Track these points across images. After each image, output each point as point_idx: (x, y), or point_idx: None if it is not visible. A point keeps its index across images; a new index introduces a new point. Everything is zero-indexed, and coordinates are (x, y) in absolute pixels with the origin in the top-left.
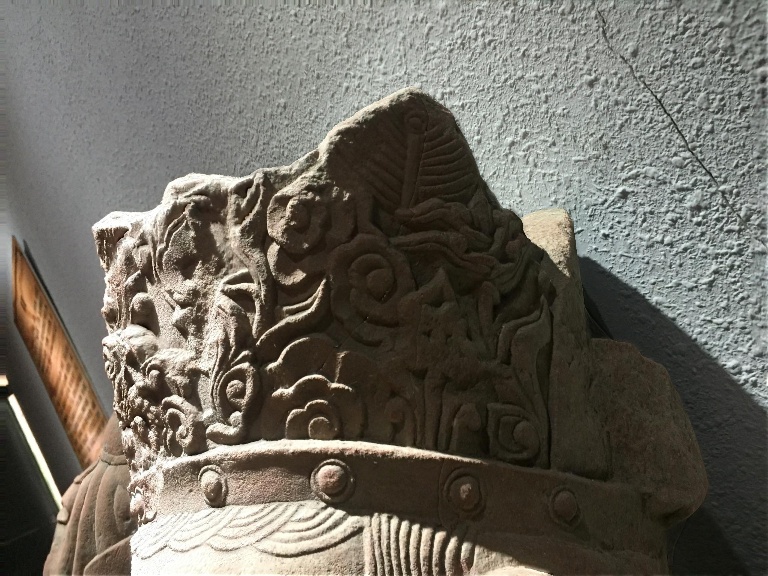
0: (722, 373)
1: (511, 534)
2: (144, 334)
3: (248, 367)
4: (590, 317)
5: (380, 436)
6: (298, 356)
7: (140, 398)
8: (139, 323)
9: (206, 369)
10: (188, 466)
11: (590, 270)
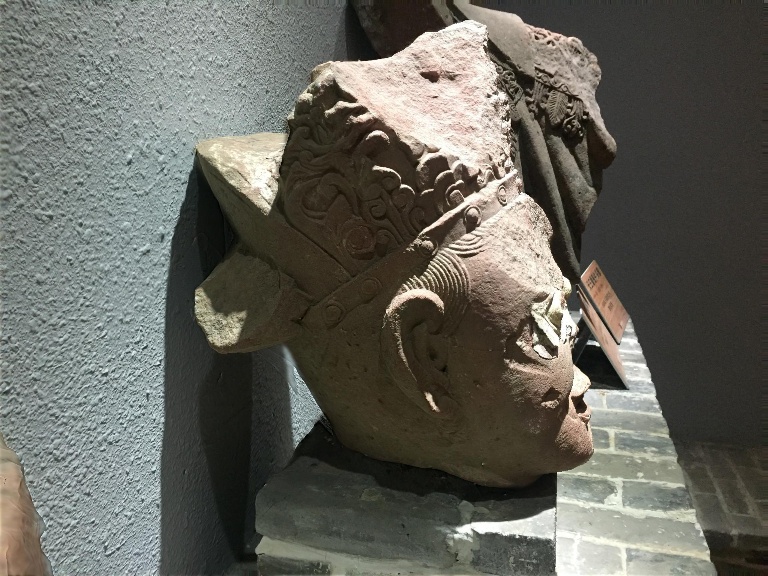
0: None
1: None
2: None
3: None
4: None
5: None
6: None
7: None
8: None
9: None
10: None
11: None
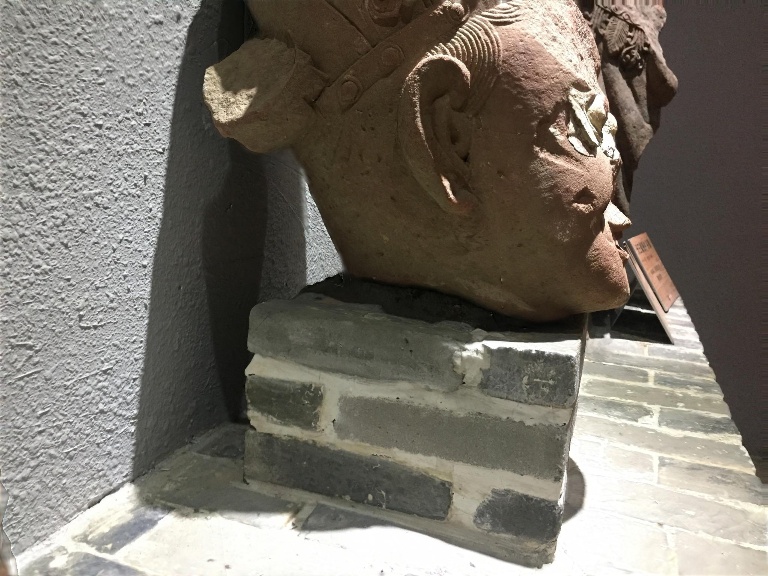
0: None
1: None
2: None
3: None
4: None
5: None
6: None
7: None
8: None
9: None
10: None
11: None
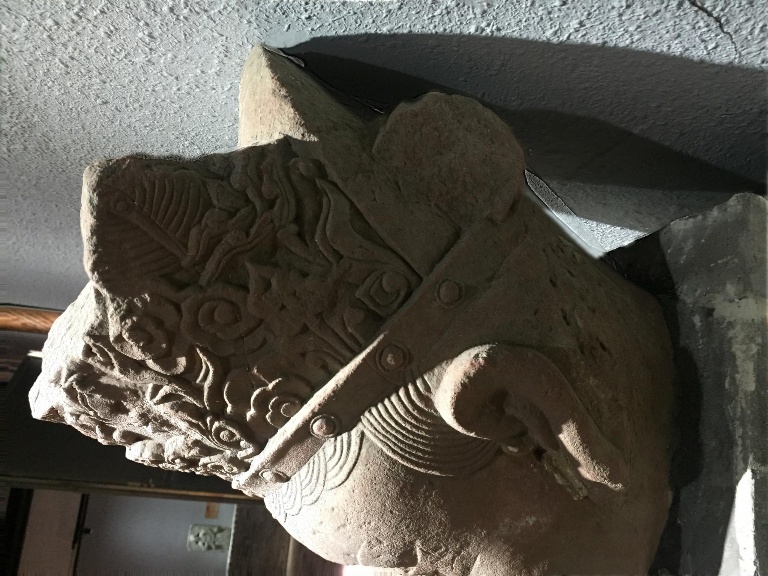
0: (473, 38)
1: (435, 345)
2: (144, 445)
3: (219, 424)
4: (358, 110)
5: (321, 379)
6: (235, 394)
7: (186, 470)
8: (134, 442)
9: (200, 439)
10: (251, 479)
11: (324, 44)
